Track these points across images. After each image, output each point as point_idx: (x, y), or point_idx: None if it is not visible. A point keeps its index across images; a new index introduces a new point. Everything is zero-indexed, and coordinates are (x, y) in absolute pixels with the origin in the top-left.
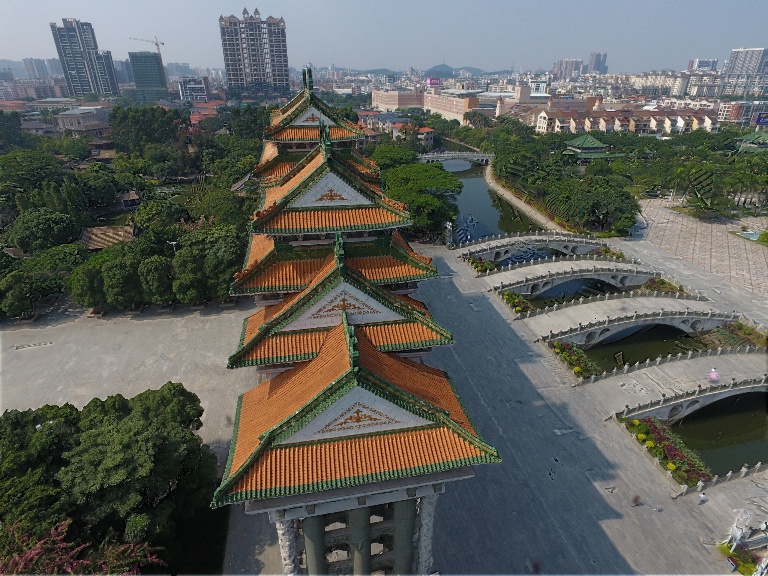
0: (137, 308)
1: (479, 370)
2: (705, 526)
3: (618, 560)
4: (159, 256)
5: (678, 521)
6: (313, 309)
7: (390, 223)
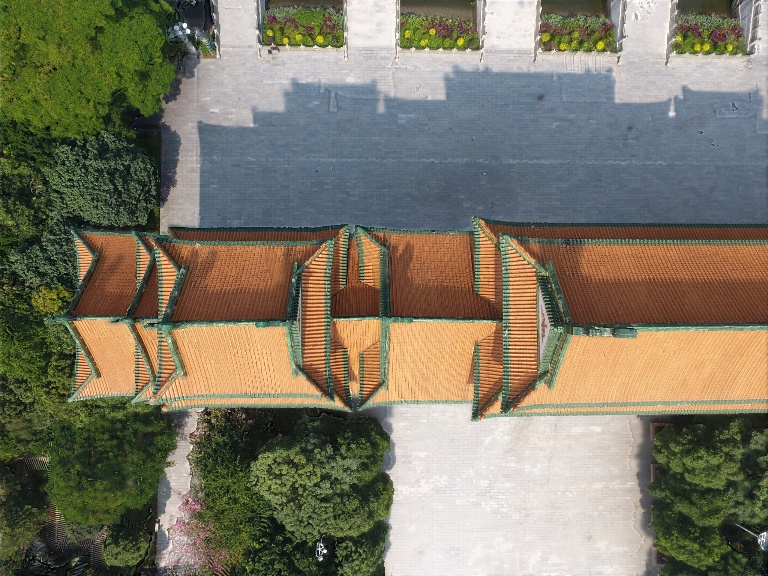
0: None
1: (575, 147)
2: None
3: None
4: (355, 560)
5: (766, 79)
6: None
7: None
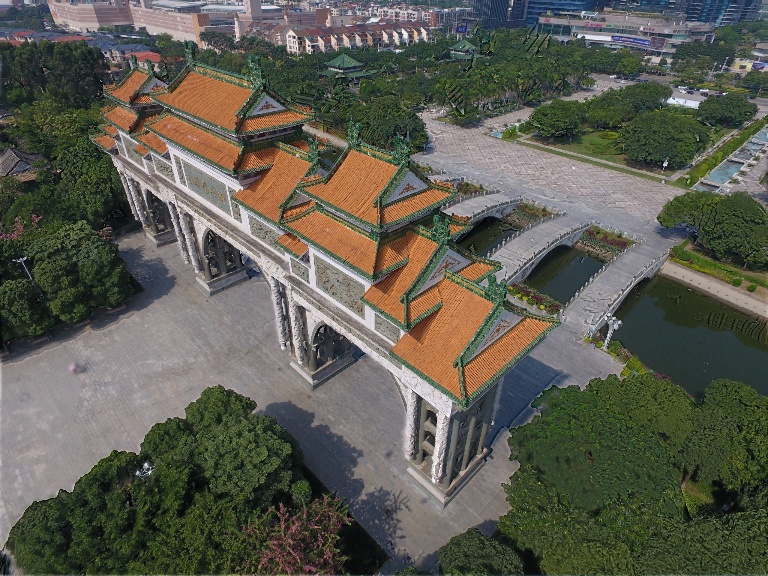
0: (1, 349)
1: None
2: (572, 332)
3: (547, 369)
4: (16, 280)
5: (560, 335)
6: (432, 274)
7: (446, 199)
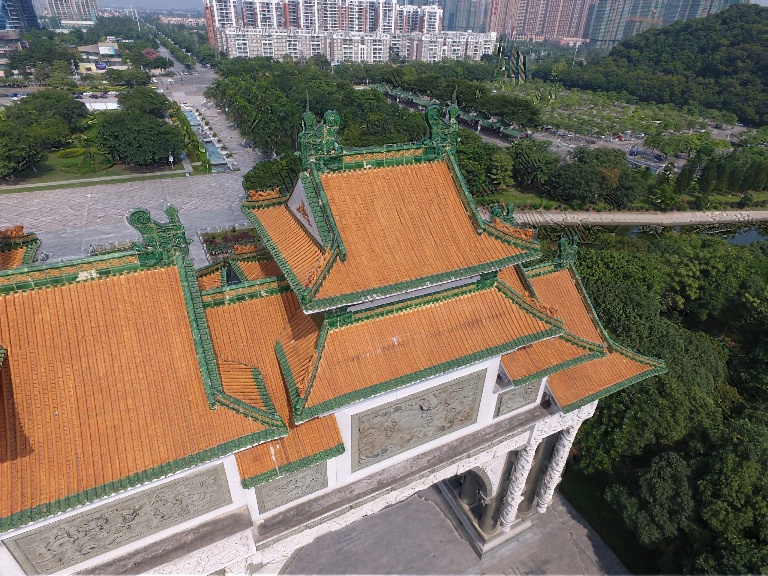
0: None
1: None
2: None
3: None
4: None
5: None
6: None
7: None
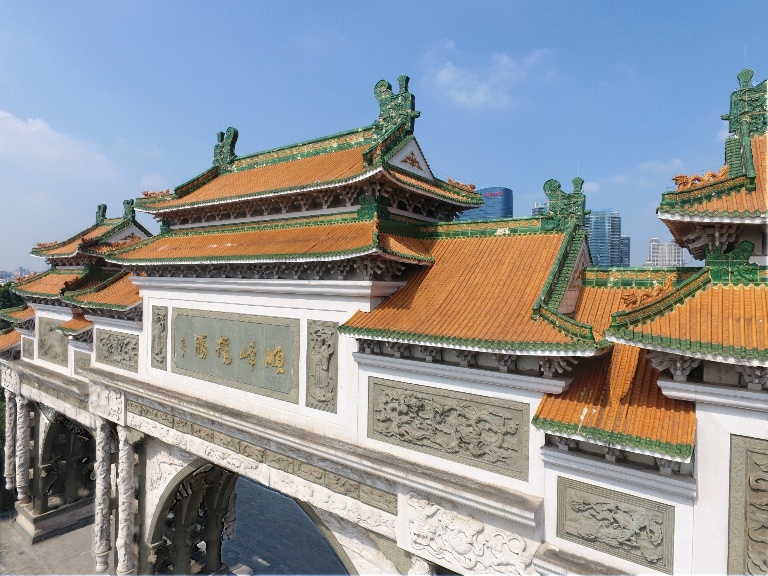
0: None
1: None
2: None
3: None
4: None
5: None
6: None
7: None
